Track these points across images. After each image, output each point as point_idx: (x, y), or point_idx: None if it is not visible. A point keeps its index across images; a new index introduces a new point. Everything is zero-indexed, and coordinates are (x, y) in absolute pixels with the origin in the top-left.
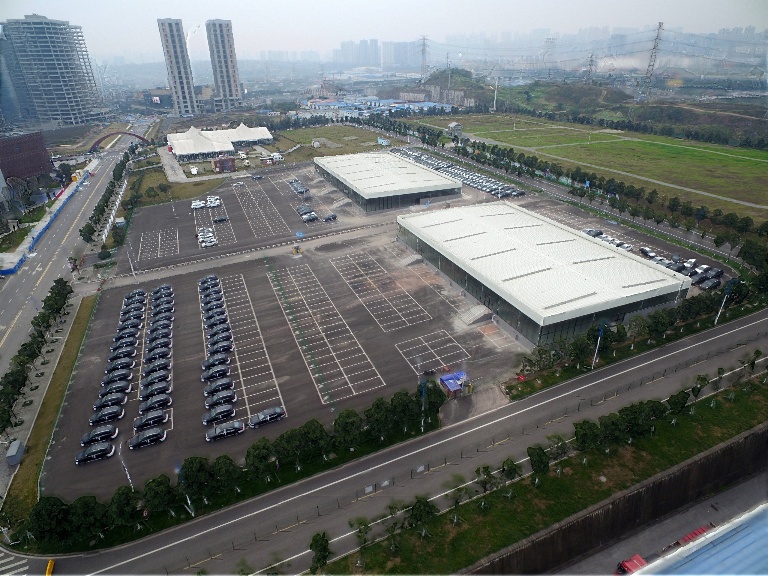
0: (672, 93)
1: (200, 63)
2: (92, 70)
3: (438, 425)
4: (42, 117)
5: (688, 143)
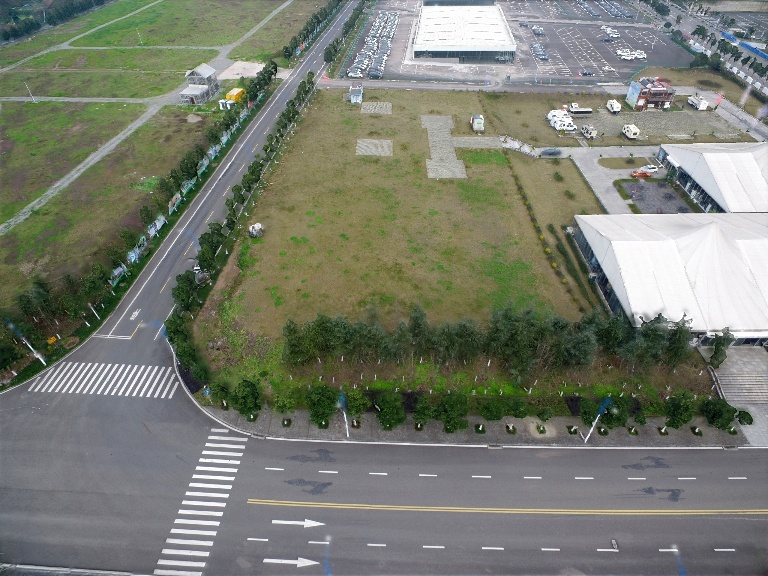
0: None
1: None
2: None
3: None
4: None
5: (65, 32)
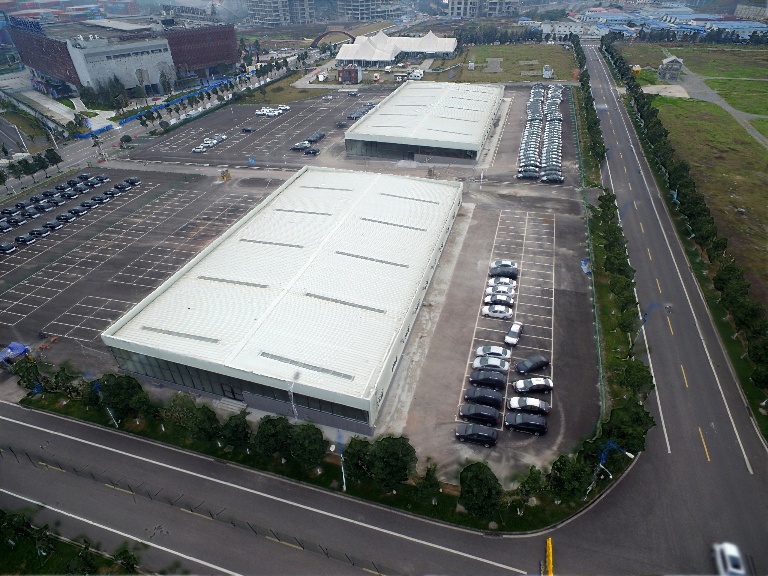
0: None
1: None
2: None
3: None
4: (340, 11)
5: None
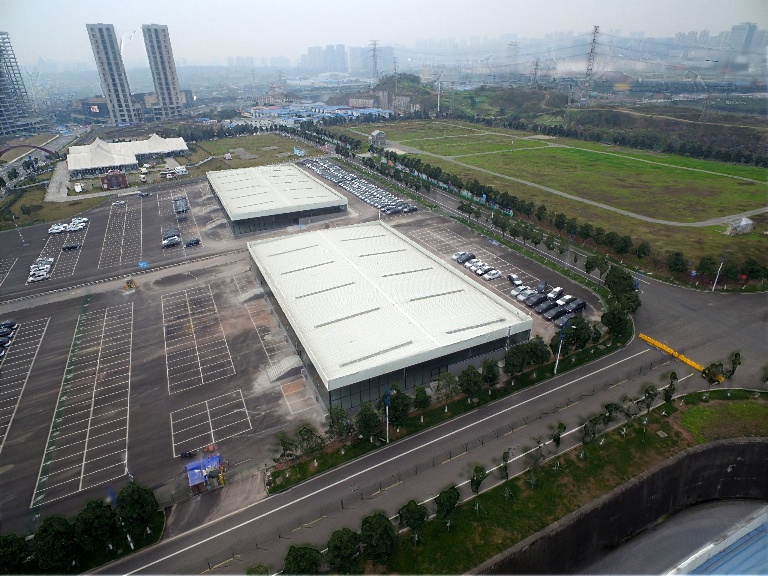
0: (612, 97)
1: (138, 70)
2: (22, 78)
3: (158, 537)
4: None
5: (613, 149)
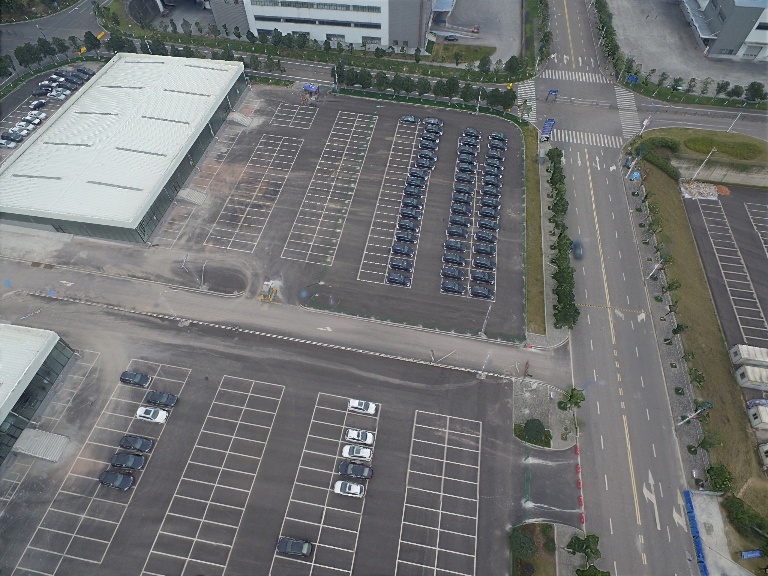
0: None
1: None
2: None
3: None
4: None
5: None
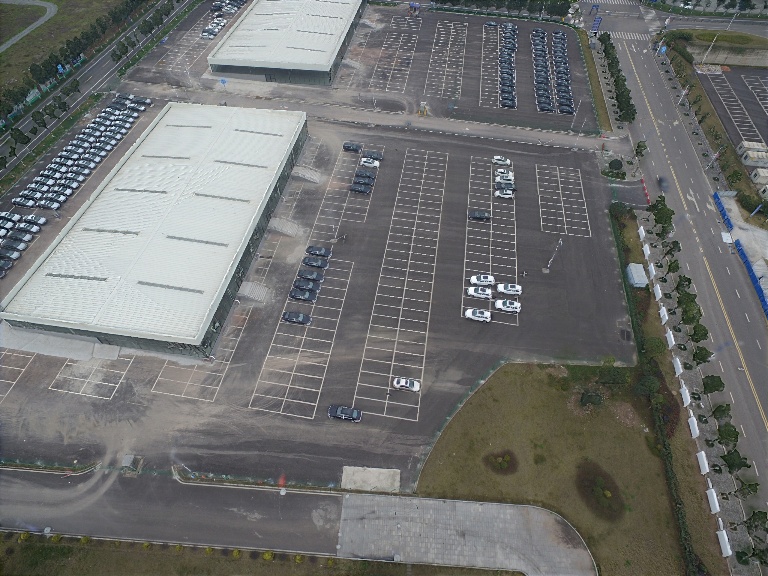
0: None
1: None
2: None
3: None
4: None
5: None
